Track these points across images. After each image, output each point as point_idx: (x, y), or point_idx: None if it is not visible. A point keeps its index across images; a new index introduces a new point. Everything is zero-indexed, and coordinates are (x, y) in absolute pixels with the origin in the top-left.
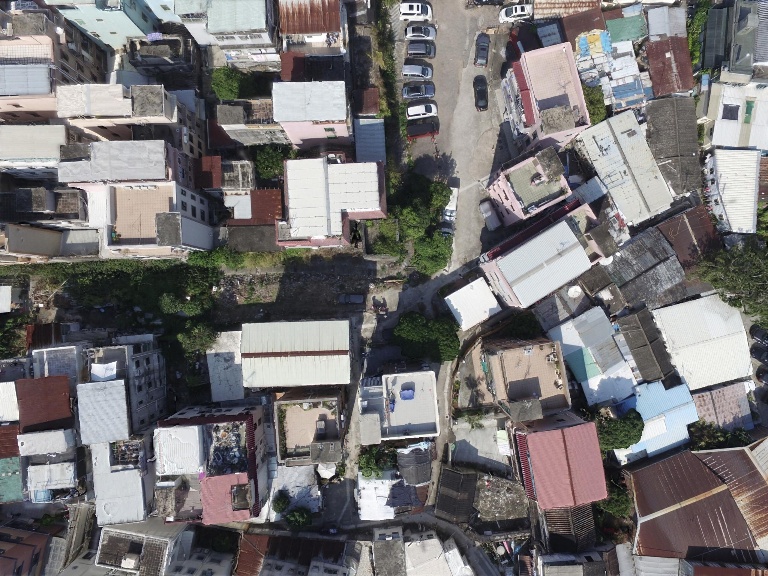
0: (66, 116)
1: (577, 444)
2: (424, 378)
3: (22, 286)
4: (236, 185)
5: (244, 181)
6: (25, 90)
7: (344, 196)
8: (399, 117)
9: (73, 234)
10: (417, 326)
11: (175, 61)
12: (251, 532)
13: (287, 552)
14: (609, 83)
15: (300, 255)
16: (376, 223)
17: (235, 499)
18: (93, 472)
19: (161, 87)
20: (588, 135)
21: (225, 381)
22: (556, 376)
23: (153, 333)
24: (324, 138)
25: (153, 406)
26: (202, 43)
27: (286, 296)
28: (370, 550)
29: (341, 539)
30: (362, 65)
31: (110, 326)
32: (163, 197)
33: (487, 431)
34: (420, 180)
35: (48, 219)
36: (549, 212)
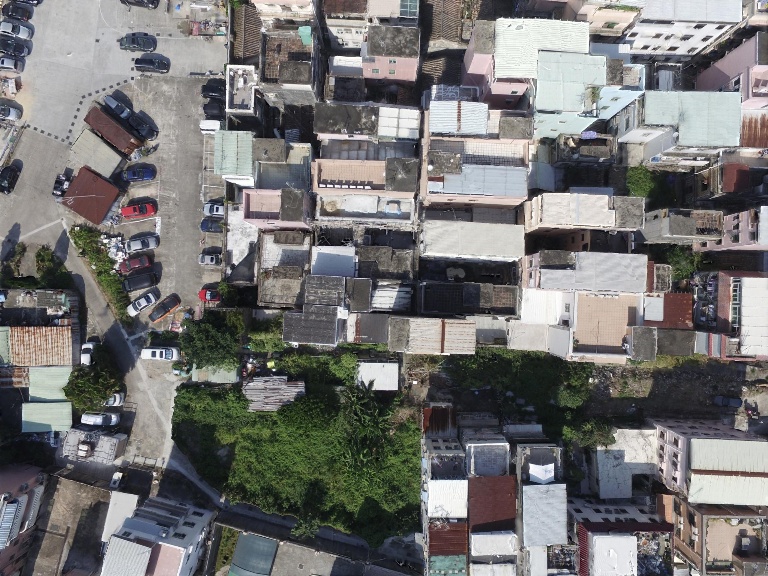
0: (551, 223)
1: None
2: None
3: (398, 362)
4: None
5: (658, 283)
6: (503, 191)
7: None
8: None
9: (469, 319)
10: None
11: (606, 160)
12: None
13: None
14: None
15: (696, 358)
16: None
17: None
18: (530, 574)
19: (642, 200)
20: None
21: (614, 479)
22: None
23: (526, 419)
24: (753, 250)
25: None
26: (620, 141)
27: (659, 392)
28: None
29: None
30: None
31: (481, 408)
32: (623, 306)
33: None
34: None
35: (485, 313)
36: None
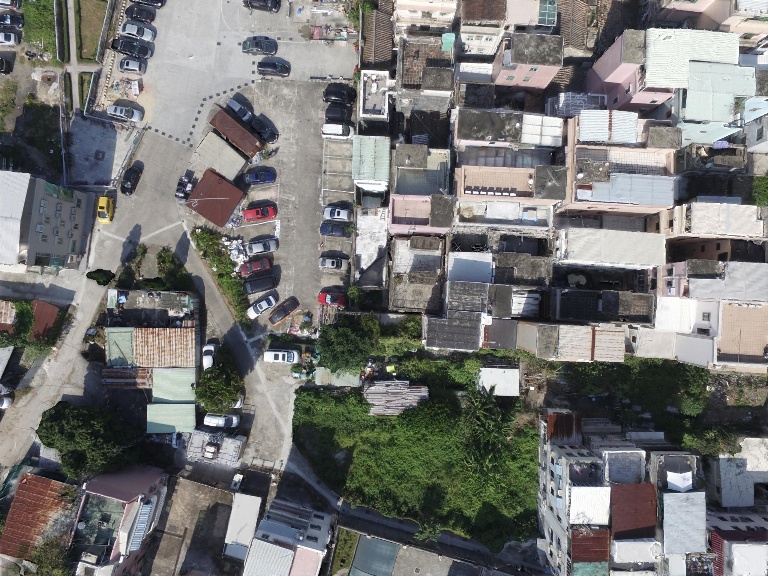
0: None
1: None
2: None
3: None
4: None
5: None
6: (649, 200)
7: None
8: None
9: None
10: None
11: (737, 170)
12: None
13: None
14: None
15: None
16: None
17: None
18: None
19: None
20: None
21: (736, 487)
22: None
23: (643, 427)
24: None
25: None
26: None
27: None
28: None
29: None
30: None
31: (597, 415)
32: (765, 316)
33: None
34: None
35: None
36: None
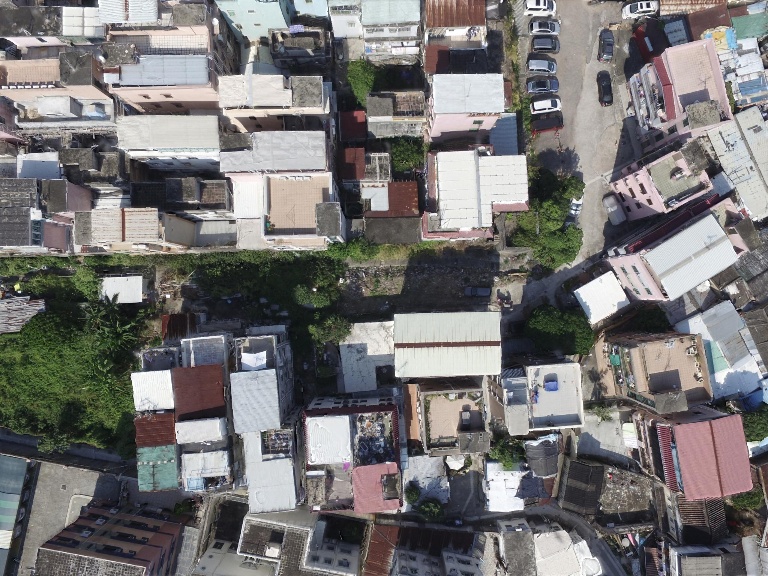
0: (227, 106)
1: (724, 436)
2: (566, 370)
3: (149, 277)
4: (373, 177)
5: (381, 173)
6: (183, 80)
7: (495, 188)
8: (523, 111)
9: (206, 225)
10: (554, 318)
11: (316, 53)
12: (379, 523)
13: (418, 543)
14: (736, 79)
15: (432, 247)
16: (515, 216)
17: (385, 488)
18: (245, 461)
19: (320, 78)
20: (714, 131)
21: (358, 372)
22: (696, 369)
23: (280, 324)
24: (465, 131)
25: (288, 396)
26: (338, 36)
27: (411, 288)
28: (495, 541)
29: (468, 530)
30: (494, 59)
31: (236, 317)
32: (317, 188)
33: (610, 424)
34: (547, 174)
35: (195, 209)
36: (686, 206)
